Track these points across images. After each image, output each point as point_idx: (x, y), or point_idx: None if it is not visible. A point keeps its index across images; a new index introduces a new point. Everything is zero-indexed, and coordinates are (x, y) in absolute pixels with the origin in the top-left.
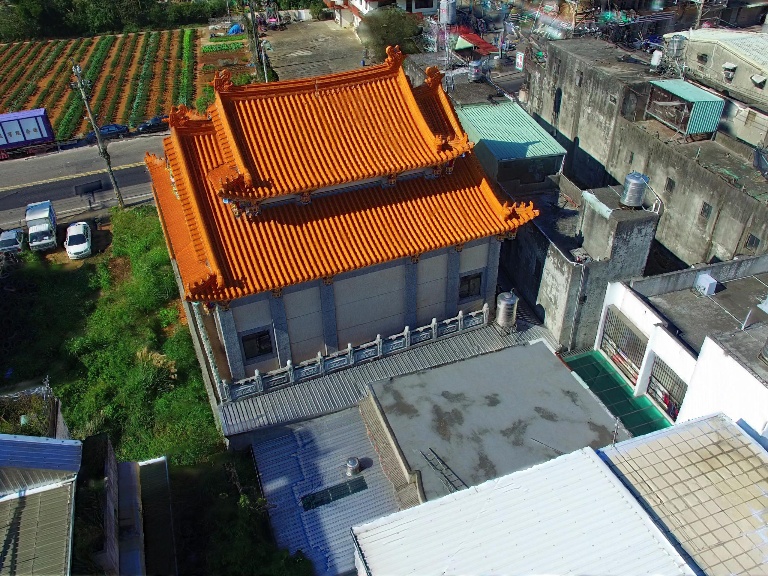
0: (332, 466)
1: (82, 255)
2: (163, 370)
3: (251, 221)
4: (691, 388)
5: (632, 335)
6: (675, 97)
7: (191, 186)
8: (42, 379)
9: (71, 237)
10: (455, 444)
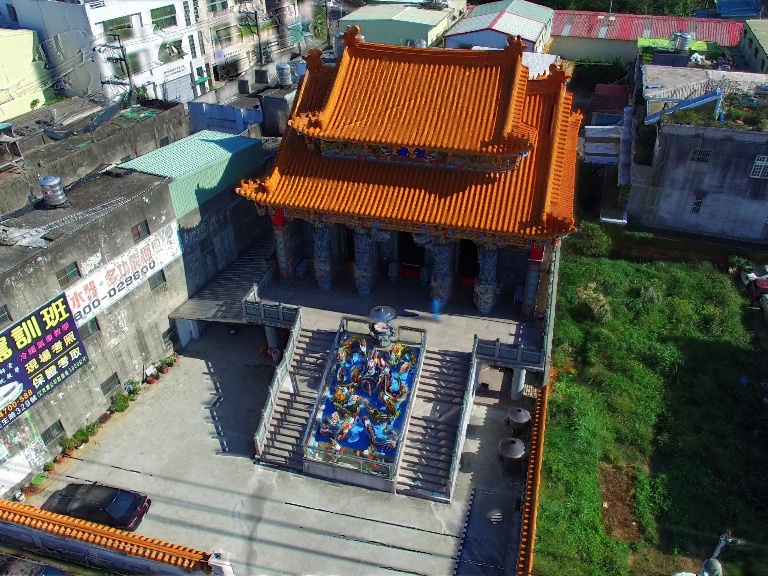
0: None
1: None
2: None
3: None
4: None
5: None
6: None
7: None
8: None
9: None
10: None
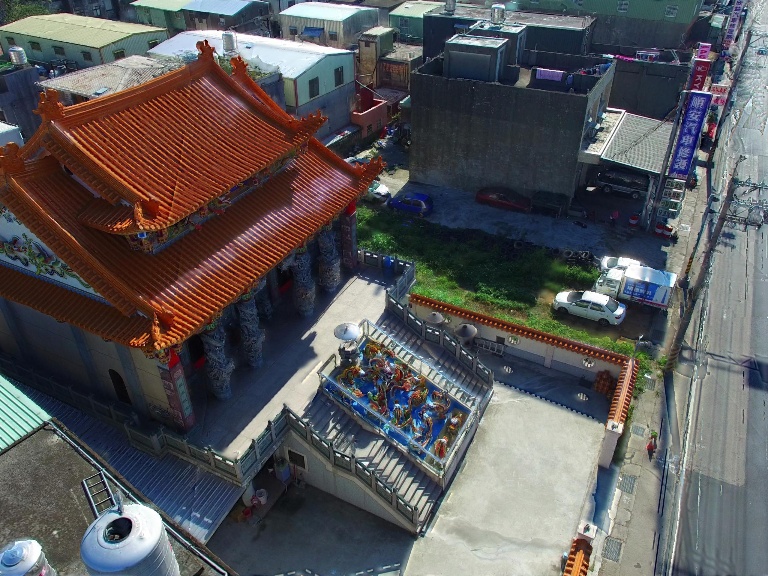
0: None
1: None
2: None
3: None
4: None
5: None
6: None
7: None
8: (376, 229)
9: None
10: None
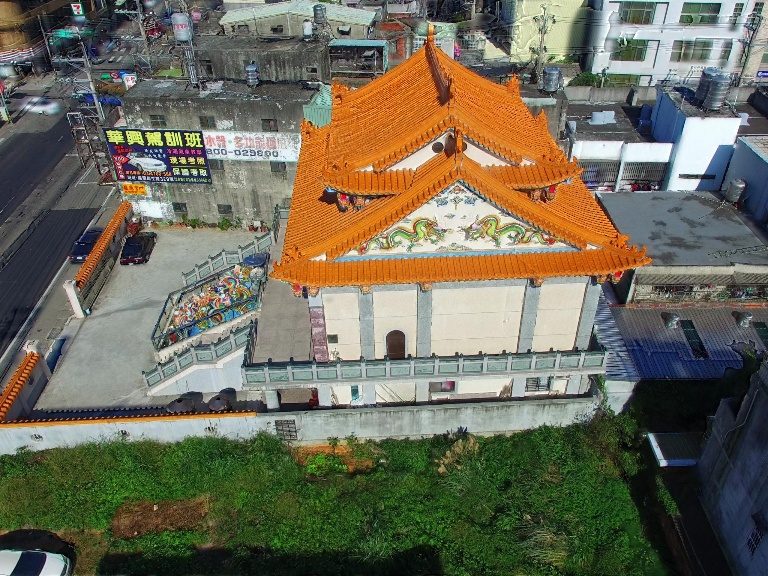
0: (666, 334)
1: (67, 571)
2: (471, 454)
3: (545, 202)
4: (679, 155)
5: (602, 165)
6: (360, 49)
7: (522, 196)
8: None
9: (14, 574)
10: (704, 245)
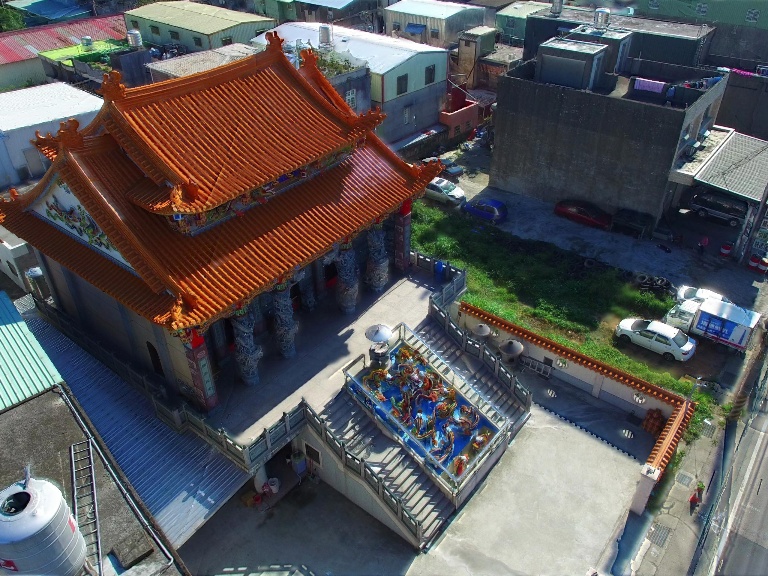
0: None
1: None
2: None
3: None
4: None
5: None
6: None
7: None
8: (443, 232)
9: None
10: None
